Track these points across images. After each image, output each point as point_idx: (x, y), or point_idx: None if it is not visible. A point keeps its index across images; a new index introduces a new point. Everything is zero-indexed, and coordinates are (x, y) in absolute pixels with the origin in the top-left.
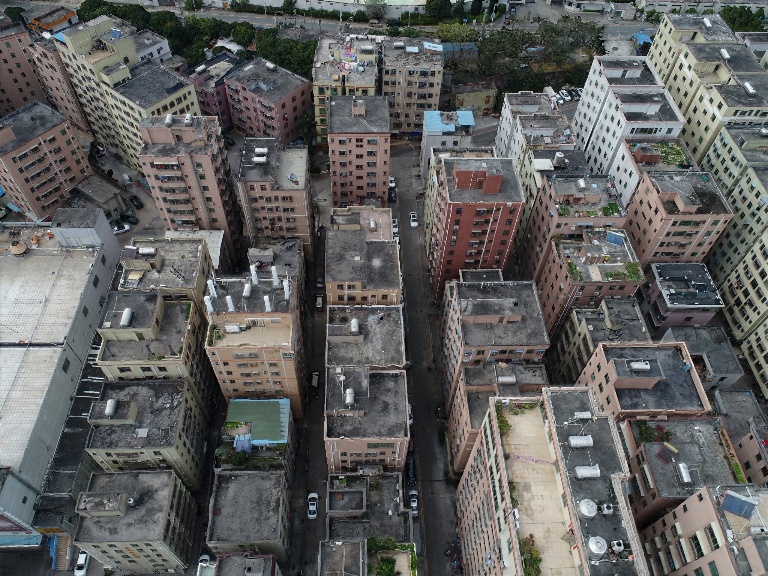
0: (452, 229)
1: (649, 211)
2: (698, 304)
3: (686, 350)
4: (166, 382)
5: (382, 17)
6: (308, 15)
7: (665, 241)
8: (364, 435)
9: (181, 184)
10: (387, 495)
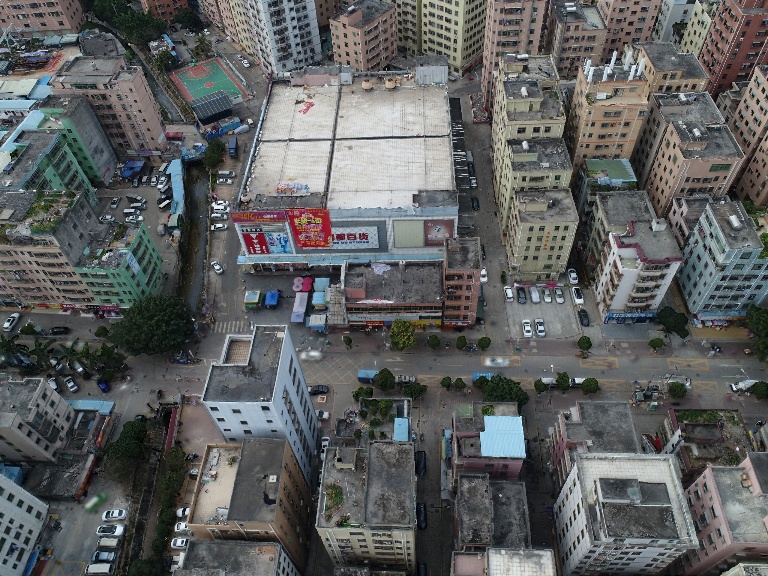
0: (737, 41)
1: None
2: None
3: None
4: (549, 140)
5: None
6: None
7: None
8: None
9: (517, 27)
10: None
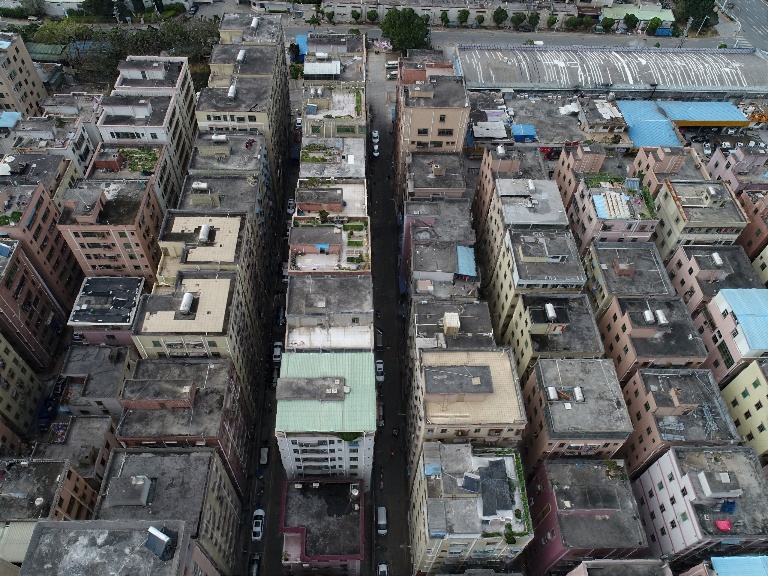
0: None
1: None
2: (101, 321)
3: None
4: None
5: (46, 14)
6: None
7: (88, 253)
8: None
9: None
10: None
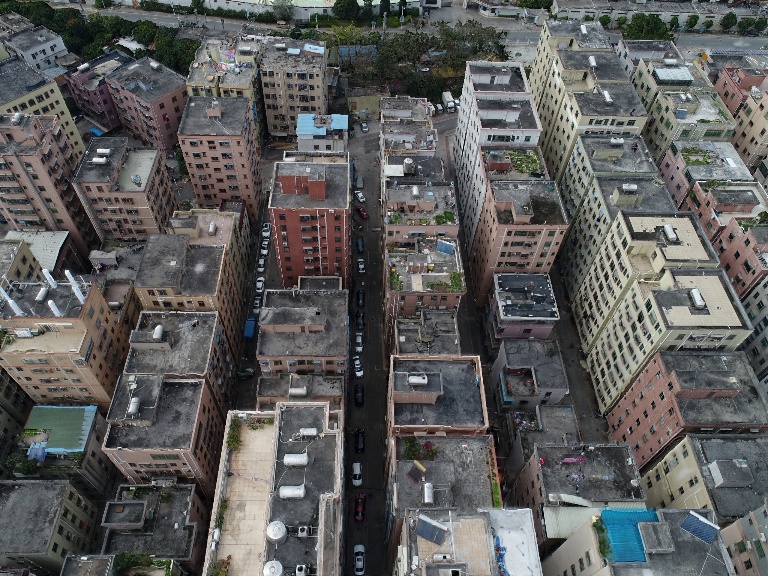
0: (281, 235)
1: (490, 220)
2: (532, 316)
3: (479, 364)
4: None
5: (291, 18)
6: (217, 15)
7: (505, 251)
8: (147, 446)
9: (14, 184)
10: (177, 508)
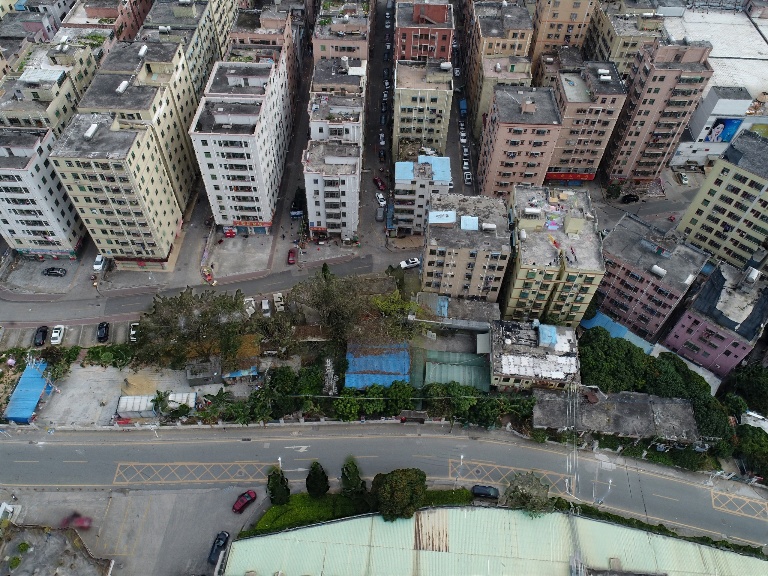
0: None
1: None
2: None
3: None
4: None
5: None
6: None
7: None
8: None
9: None
10: None
